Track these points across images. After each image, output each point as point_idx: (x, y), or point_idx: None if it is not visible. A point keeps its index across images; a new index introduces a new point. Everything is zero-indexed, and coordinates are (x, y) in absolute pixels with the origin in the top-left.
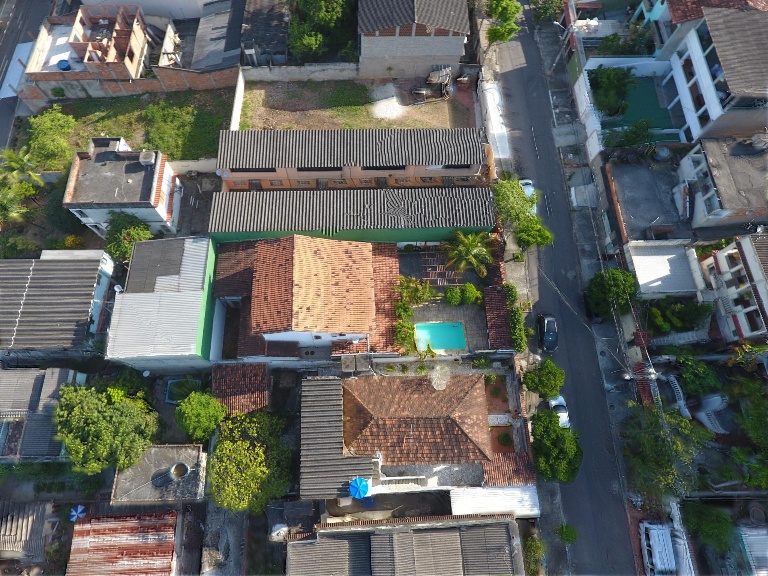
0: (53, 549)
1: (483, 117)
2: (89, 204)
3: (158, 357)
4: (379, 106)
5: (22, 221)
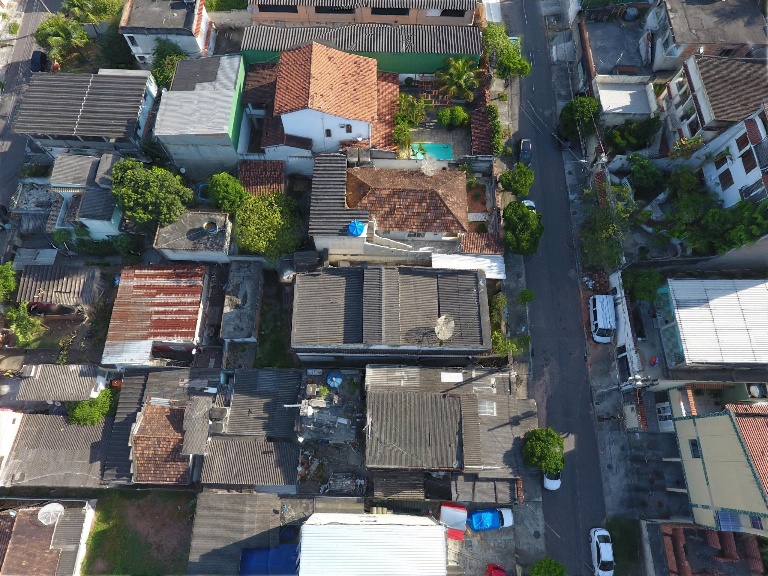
0: (100, 307)
1: None
2: (141, 29)
3: (196, 139)
4: None
5: (78, 63)
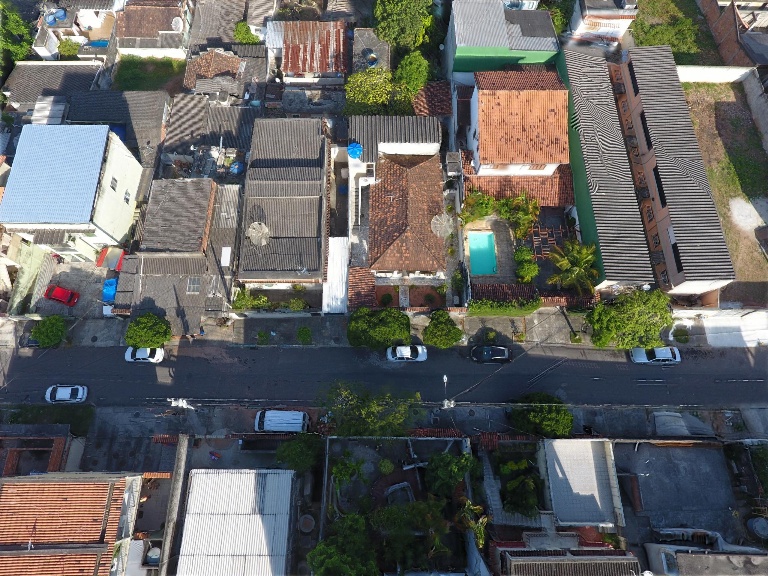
0: None
1: (760, 309)
2: None
3: None
4: (747, 208)
5: None
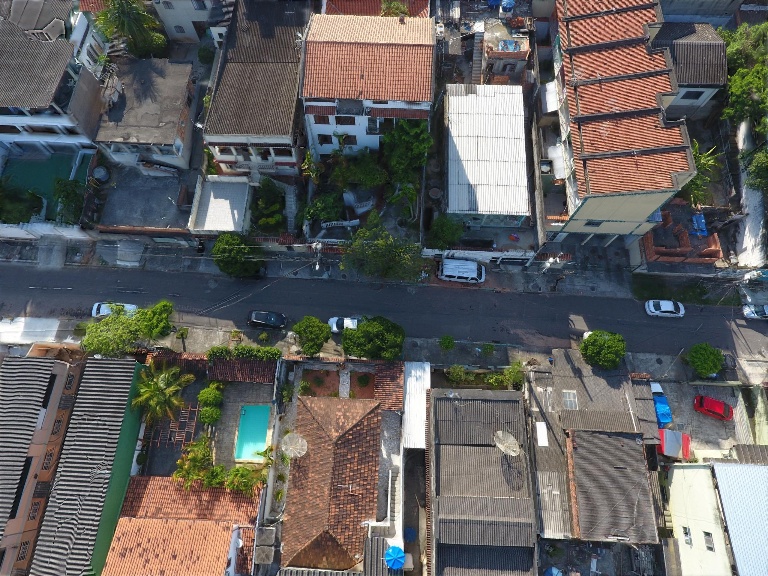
0: None
1: None
2: None
3: None
4: None
5: None
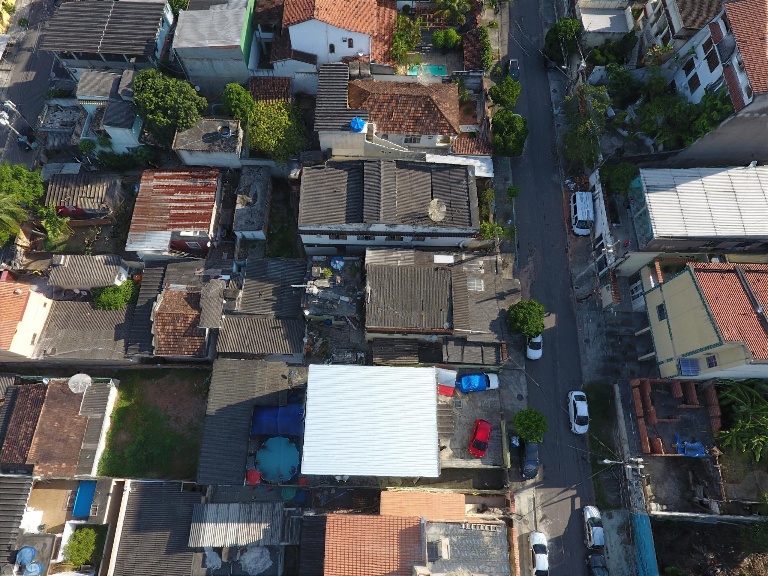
0: (121, 212)
1: None
2: None
3: (211, 52)
4: None
5: None
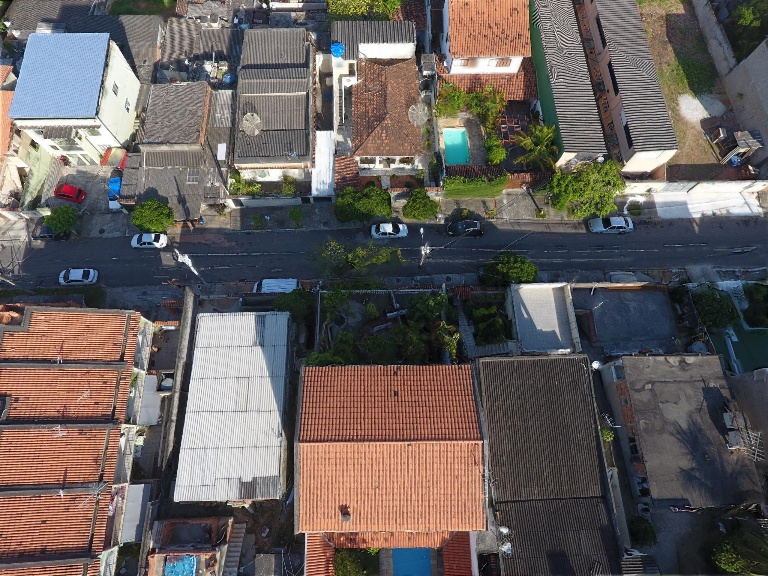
0: None
1: None
2: None
3: None
4: (694, 103)
5: None
